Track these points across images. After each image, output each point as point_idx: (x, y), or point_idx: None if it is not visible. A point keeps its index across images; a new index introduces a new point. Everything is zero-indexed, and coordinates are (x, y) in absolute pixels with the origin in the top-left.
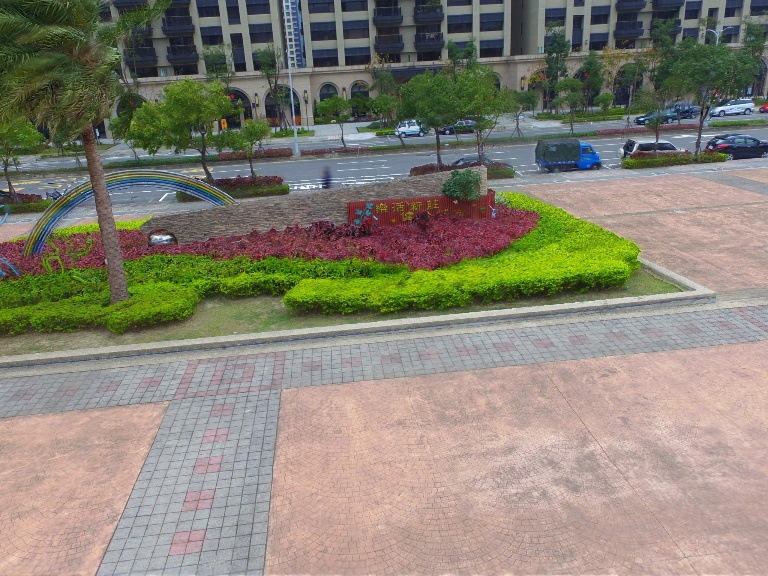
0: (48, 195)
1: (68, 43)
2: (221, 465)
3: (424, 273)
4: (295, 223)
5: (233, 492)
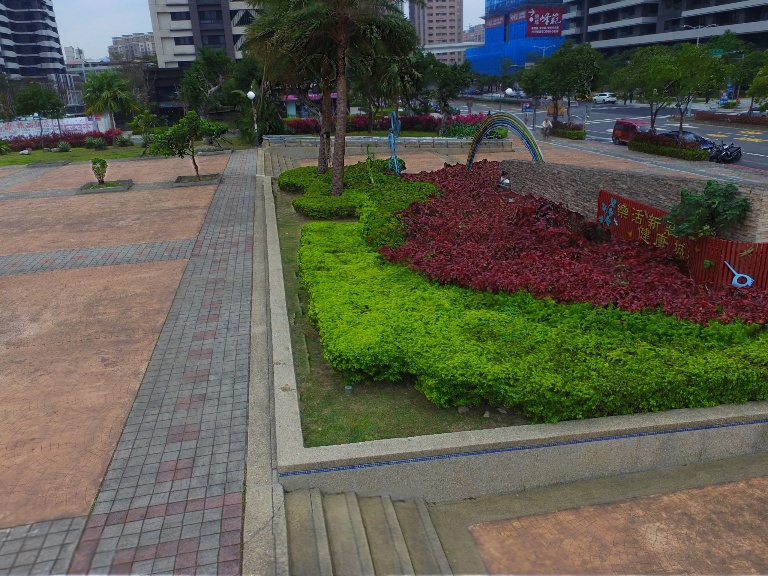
0: (714, 146)
1: (299, 3)
2: (107, 257)
3: (366, 255)
4: (567, 200)
5: (78, 262)
